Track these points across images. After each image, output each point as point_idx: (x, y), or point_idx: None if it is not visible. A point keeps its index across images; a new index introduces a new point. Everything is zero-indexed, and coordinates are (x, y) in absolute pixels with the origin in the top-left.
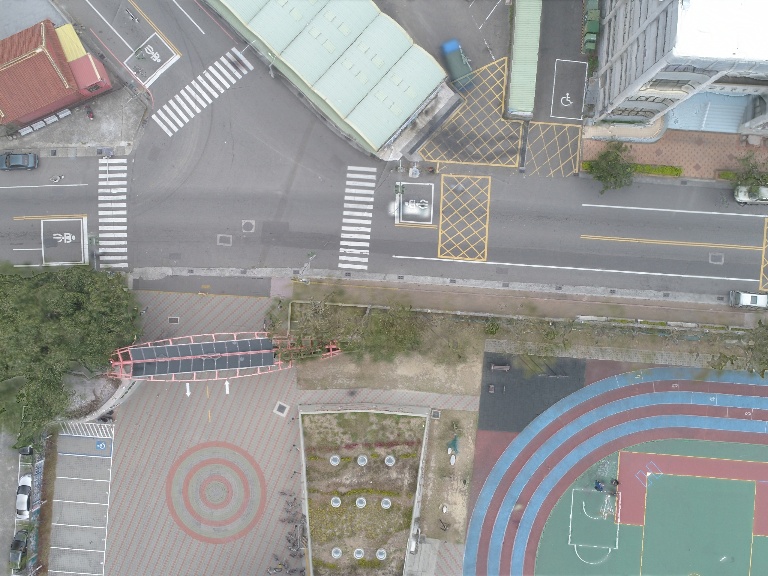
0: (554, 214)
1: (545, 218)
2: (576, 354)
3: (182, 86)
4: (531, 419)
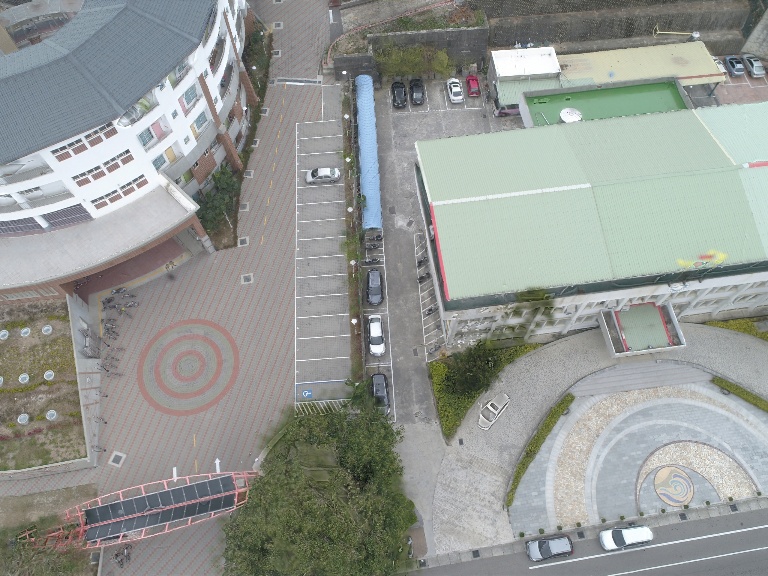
0: None
1: None
2: None
3: None
4: None
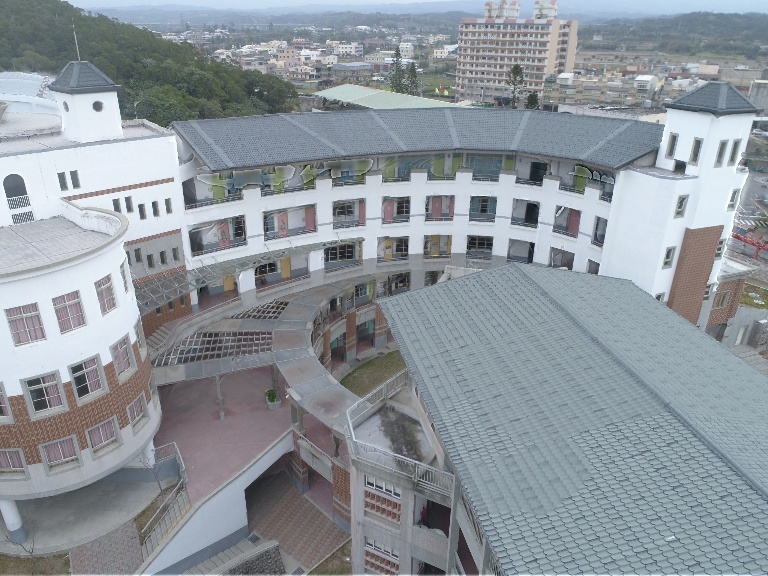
0: None
1: None
2: None
3: (763, 221)
4: None
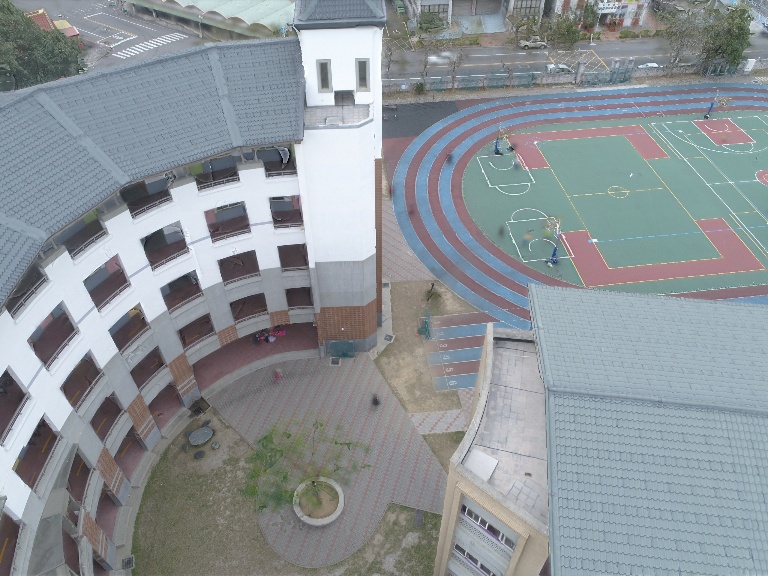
0: (405, 62)
1: (399, 63)
2: (445, 100)
3: (137, 44)
4: (424, 129)
